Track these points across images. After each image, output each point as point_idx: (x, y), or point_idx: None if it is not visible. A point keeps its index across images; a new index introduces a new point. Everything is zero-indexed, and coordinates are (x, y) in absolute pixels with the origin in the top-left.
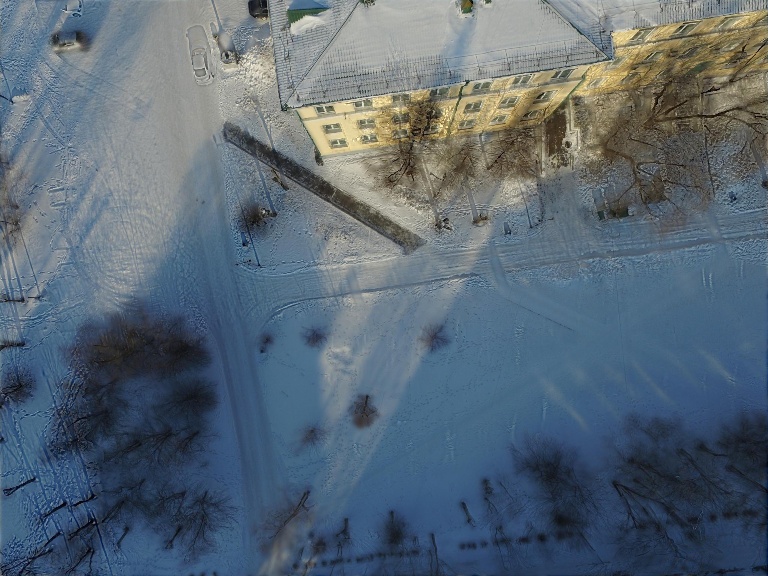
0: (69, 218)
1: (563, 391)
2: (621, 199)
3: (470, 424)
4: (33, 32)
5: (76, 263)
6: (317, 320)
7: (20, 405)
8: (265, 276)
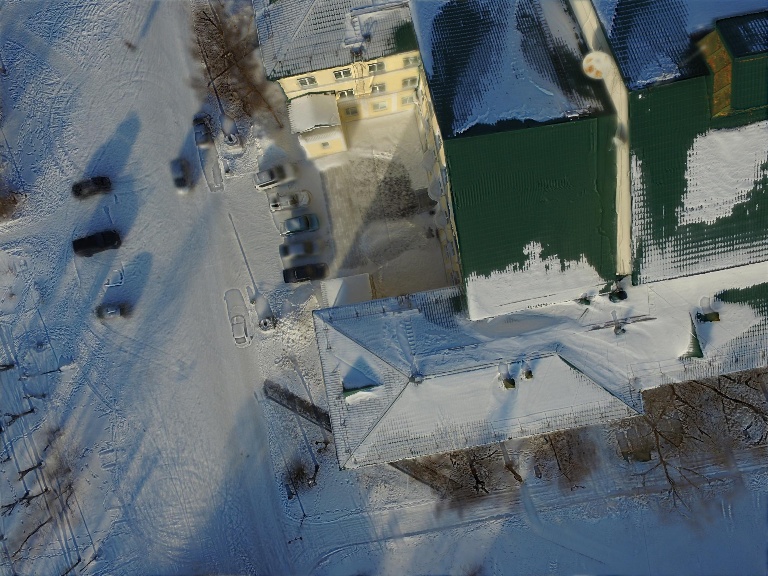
0: (120, 478)
1: None
2: (643, 440)
3: None
4: (76, 302)
5: (129, 520)
6: (362, 565)
7: None
8: (310, 524)
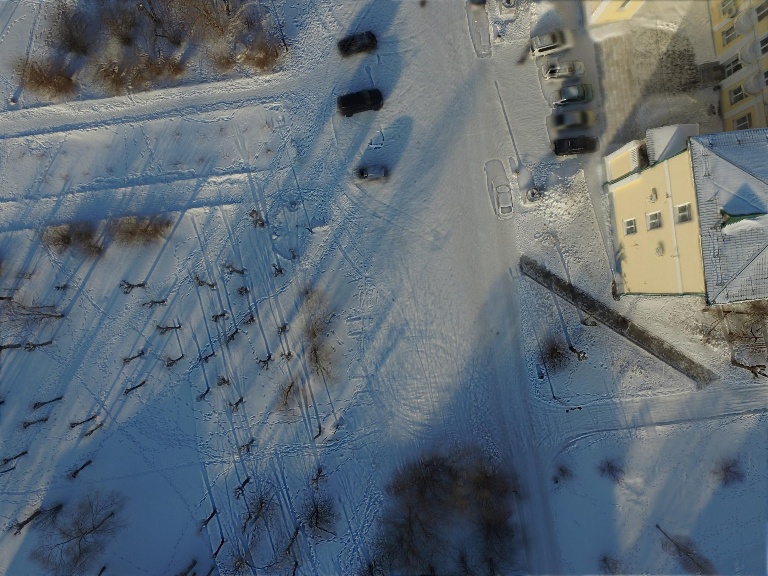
0: (366, 347)
1: None
2: None
3: (759, 555)
4: (332, 162)
5: (371, 391)
6: (611, 452)
7: (316, 531)
8: (559, 407)
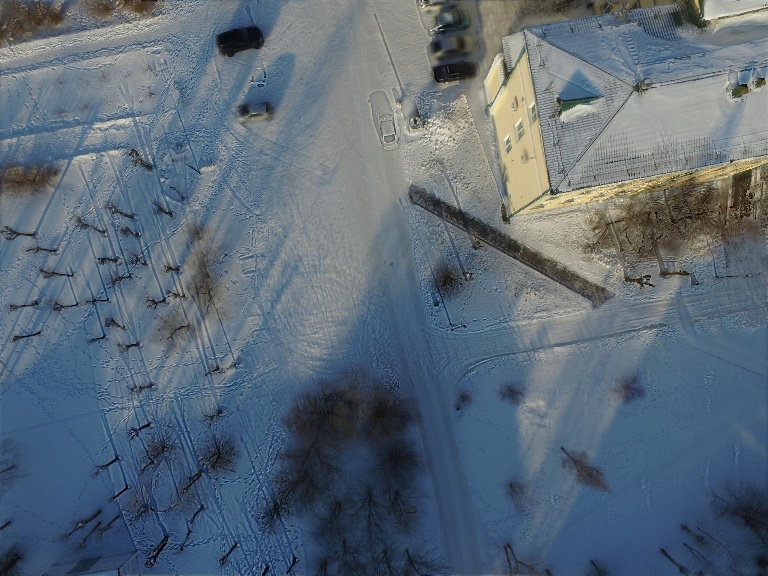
0: (260, 285)
1: (754, 435)
2: None
3: (665, 471)
4: (217, 103)
5: (268, 329)
6: (510, 376)
7: (220, 472)
8: (456, 334)
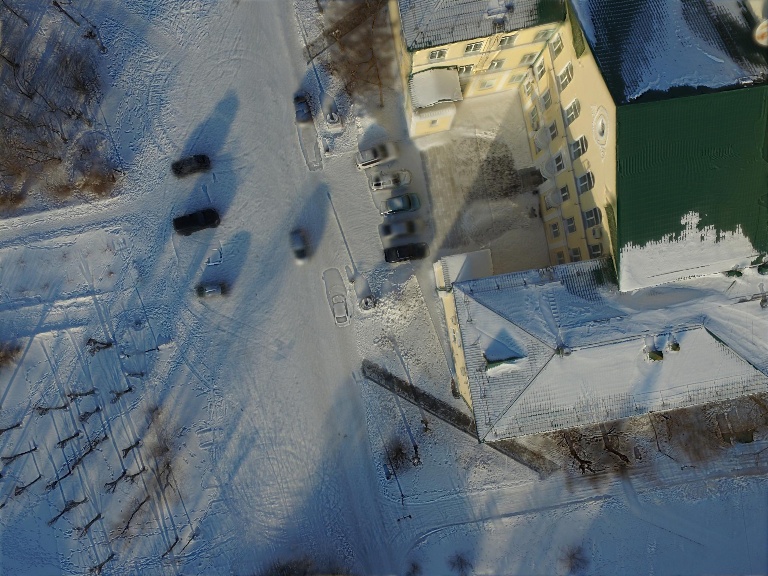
0: (217, 457)
1: None
2: (744, 422)
3: None
4: (174, 280)
5: (226, 500)
6: (460, 545)
7: None
8: (408, 504)
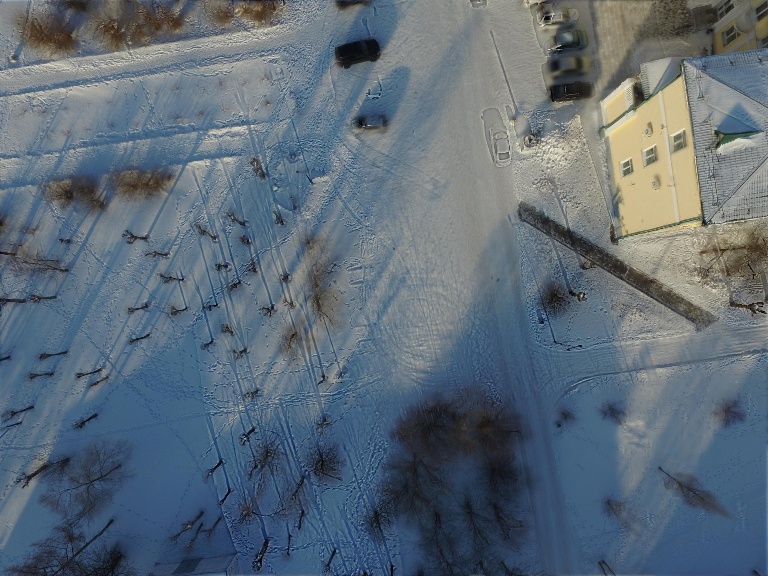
0: (367, 296)
1: None
2: None
3: (761, 495)
4: (331, 114)
5: (374, 340)
6: (612, 395)
7: (322, 479)
8: (560, 352)
